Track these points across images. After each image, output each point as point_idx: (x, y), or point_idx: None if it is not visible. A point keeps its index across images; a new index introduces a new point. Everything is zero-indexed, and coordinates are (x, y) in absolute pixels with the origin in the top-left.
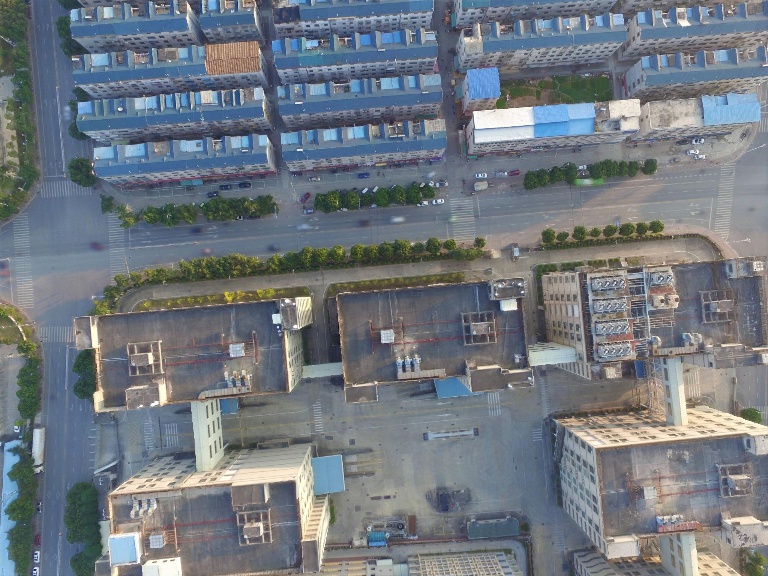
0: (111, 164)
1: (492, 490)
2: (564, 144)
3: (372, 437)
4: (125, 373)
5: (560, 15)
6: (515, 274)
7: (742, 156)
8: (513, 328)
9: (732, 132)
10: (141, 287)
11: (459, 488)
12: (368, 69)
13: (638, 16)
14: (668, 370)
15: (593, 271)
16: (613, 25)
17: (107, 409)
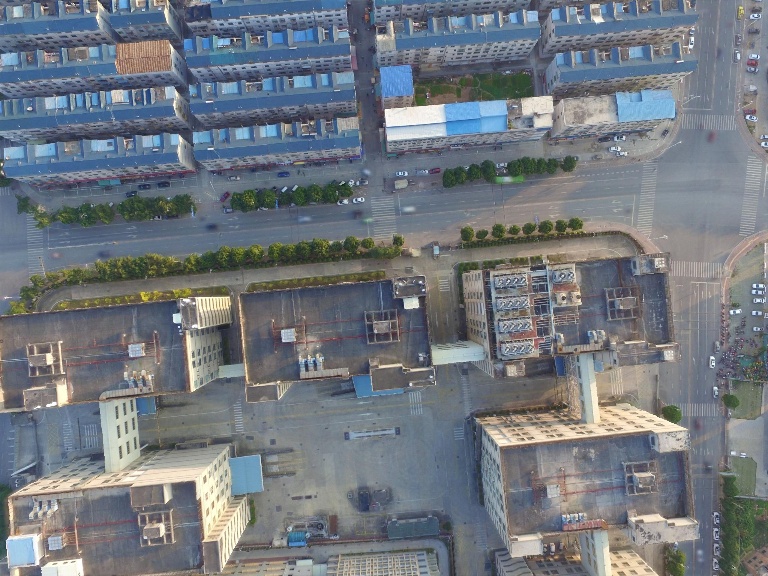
0: (20, 164)
1: (414, 489)
2: (482, 142)
3: (293, 437)
4: (26, 374)
5: (478, 12)
6: (436, 272)
7: (664, 153)
8: (417, 326)
9: (654, 129)
10: (60, 288)
11: (381, 487)
12: (283, 67)
13: (552, 13)
14: (580, 368)
15: (496, 269)
16: (527, 22)
17: (6, 410)
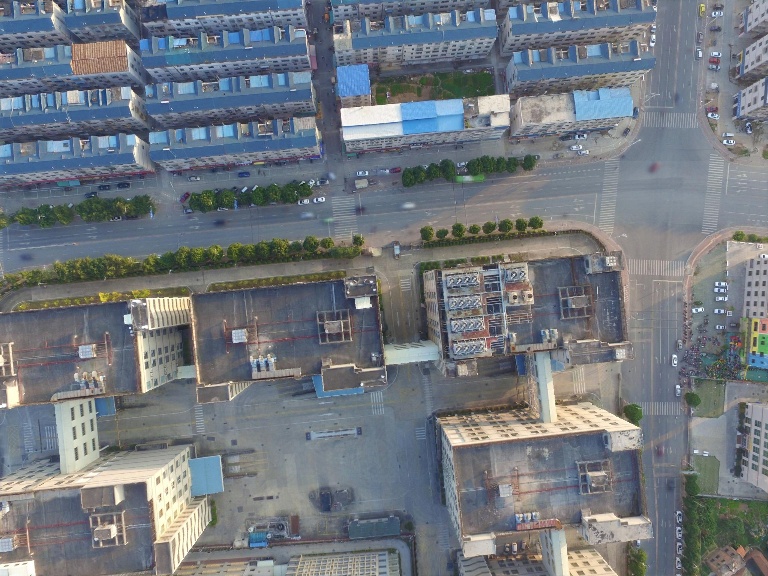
0: None
1: (376, 489)
2: (442, 141)
3: (254, 437)
4: None
5: (438, 11)
6: (398, 272)
7: (626, 151)
8: (370, 326)
9: (616, 127)
10: (19, 289)
11: (342, 488)
12: (241, 67)
13: (510, 11)
14: (537, 367)
15: None
16: (484, 20)
17: None
